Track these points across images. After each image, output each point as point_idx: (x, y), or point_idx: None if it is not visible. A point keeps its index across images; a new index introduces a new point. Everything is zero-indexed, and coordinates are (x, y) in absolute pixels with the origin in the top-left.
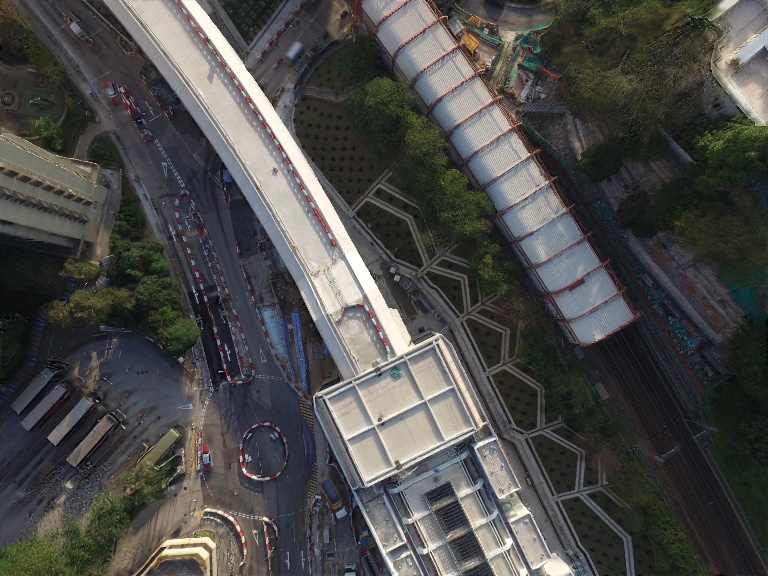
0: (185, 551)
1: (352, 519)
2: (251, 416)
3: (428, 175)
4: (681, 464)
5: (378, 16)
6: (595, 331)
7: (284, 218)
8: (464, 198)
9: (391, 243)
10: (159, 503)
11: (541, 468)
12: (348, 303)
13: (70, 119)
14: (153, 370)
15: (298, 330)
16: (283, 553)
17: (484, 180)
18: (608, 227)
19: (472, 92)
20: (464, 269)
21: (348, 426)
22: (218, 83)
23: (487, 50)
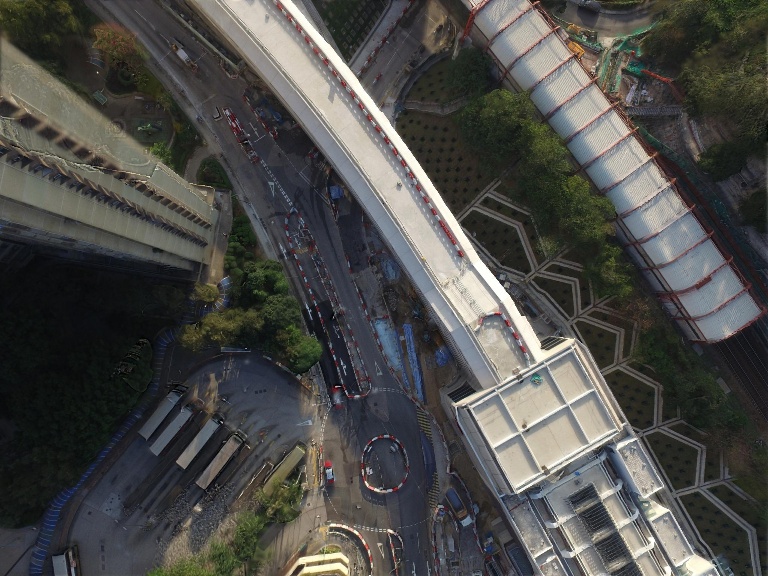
0: (326, 567)
1: (476, 526)
2: (370, 429)
3: (551, 182)
4: None
5: (493, 29)
6: (724, 327)
7: (411, 232)
8: (591, 203)
9: (498, 250)
10: None
11: (658, 465)
12: (485, 312)
13: (180, 144)
14: (271, 388)
15: (411, 341)
16: (409, 564)
17: (605, 185)
18: (725, 225)
19: (590, 99)
20: (576, 273)
21: (493, 434)
22: (339, 102)
23: (589, 57)
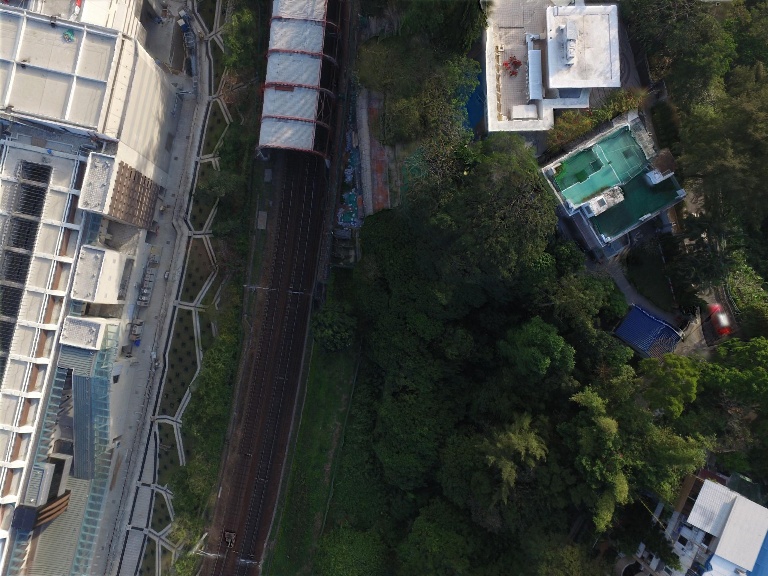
0: None
1: None
2: None
3: None
4: (280, 326)
5: None
6: (271, 139)
7: None
8: None
9: None
10: None
11: (184, 270)
12: None
13: None
14: None
15: None
16: None
17: None
18: None
19: None
20: None
21: None
22: None
23: None
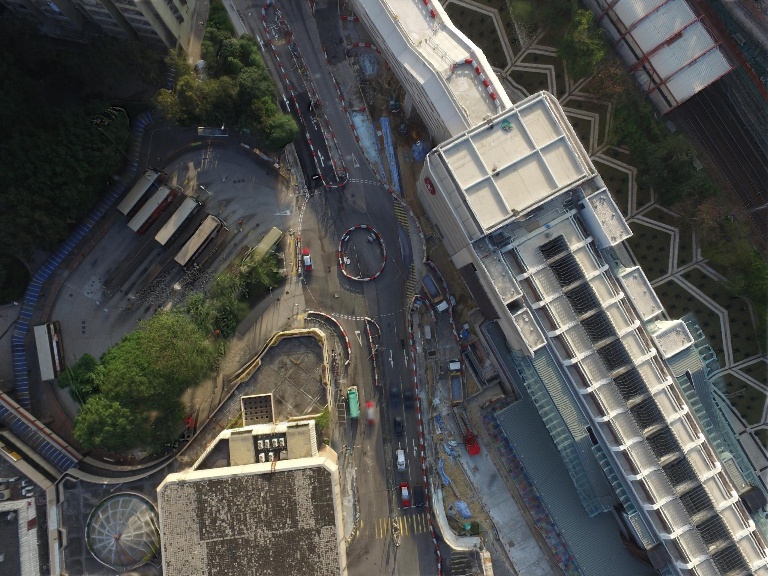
0: (301, 330)
1: (452, 315)
2: (347, 220)
3: None
4: None
5: None
6: (694, 84)
7: None
8: None
9: None
10: (263, 308)
11: (632, 258)
12: (456, 61)
13: None
14: (249, 178)
15: (388, 135)
16: (386, 352)
17: None
18: None
19: None
20: (551, 59)
21: (464, 178)
22: None
23: None
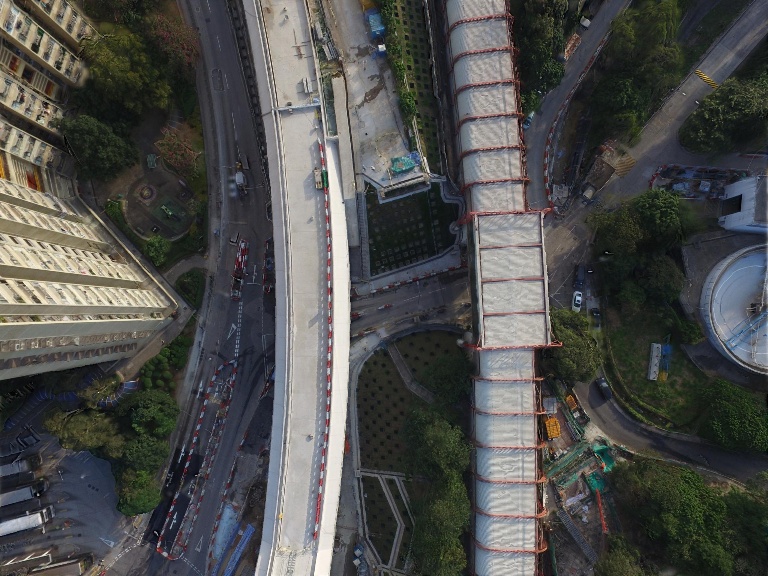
0: None
1: None
2: None
3: (435, 537)
4: None
5: (486, 373)
6: None
7: (289, 483)
8: None
9: (373, 525)
10: None
11: None
12: None
13: (183, 245)
14: (103, 492)
15: (245, 542)
16: None
17: (480, 574)
18: None
19: (521, 495)
20: None
21: None
22: (315, 332)
23: (565, 437)
